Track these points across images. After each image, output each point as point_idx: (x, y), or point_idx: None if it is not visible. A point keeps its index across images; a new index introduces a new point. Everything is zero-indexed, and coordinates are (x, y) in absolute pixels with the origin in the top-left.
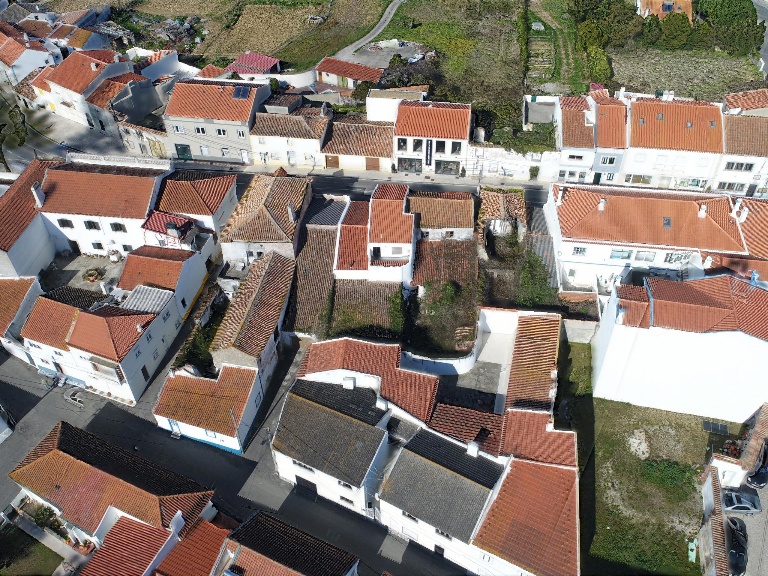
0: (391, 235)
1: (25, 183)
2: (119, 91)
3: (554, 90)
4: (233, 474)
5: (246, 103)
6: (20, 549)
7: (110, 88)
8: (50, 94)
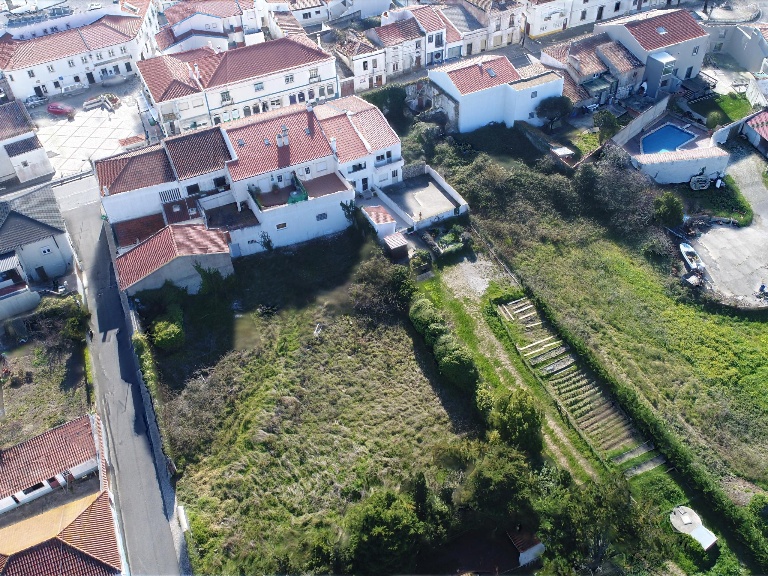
0: None
1: None
2: None
3: (464, 272)
4: (392, 0)
5: None
6: None
7: None
8: None
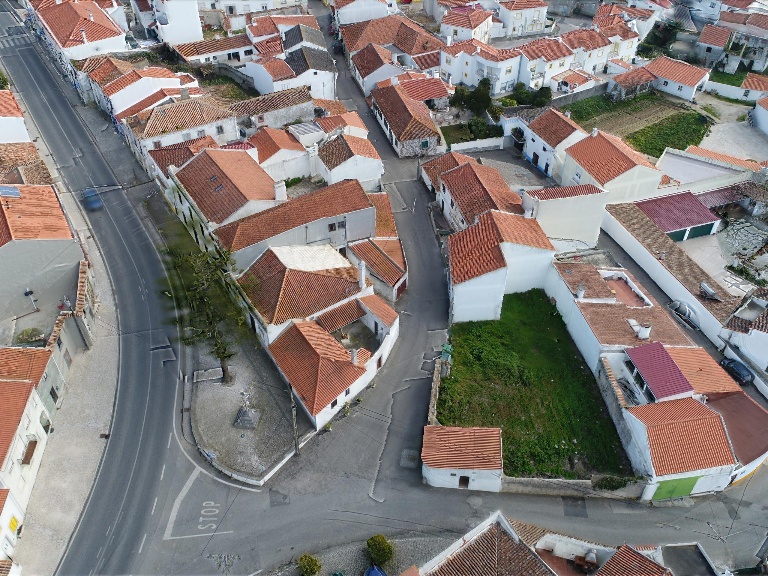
0: (168, 73)
1: (276, 211)
2: (6, 350)
3: None
4: None
5: (24, 189)
6: (454, 140)
7: (0, 367)
8: (8, 498)
